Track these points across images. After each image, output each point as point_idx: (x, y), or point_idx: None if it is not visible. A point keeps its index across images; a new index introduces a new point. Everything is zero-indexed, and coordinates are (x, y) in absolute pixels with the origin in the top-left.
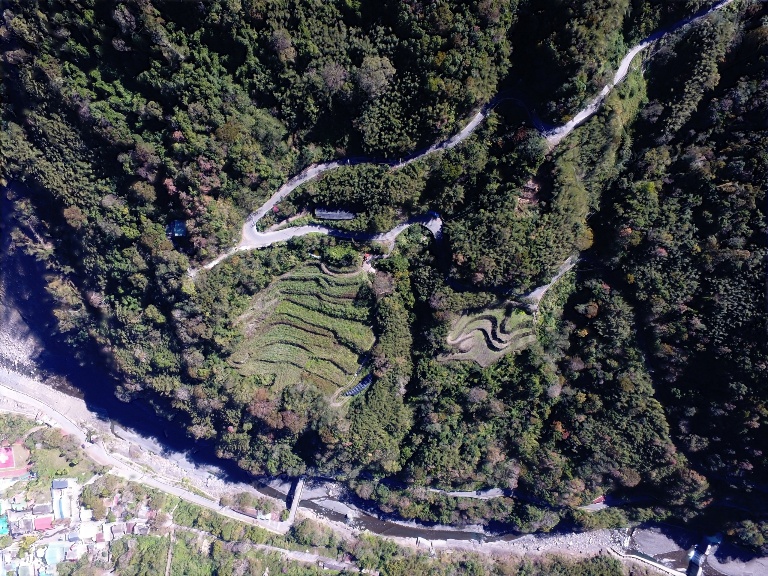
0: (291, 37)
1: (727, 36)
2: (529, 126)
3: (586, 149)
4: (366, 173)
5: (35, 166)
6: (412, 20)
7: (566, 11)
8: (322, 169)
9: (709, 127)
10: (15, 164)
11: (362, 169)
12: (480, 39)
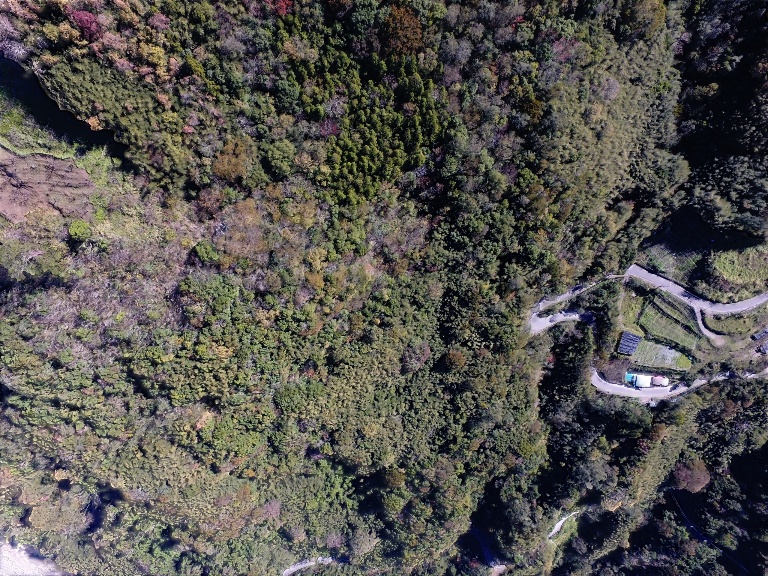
0: (304, 526)
1: (637, 520)
2: (481, 559)
3: (524, 574)
4: (352, 575)
5: (102, 574)
6: (395, 523)
7: (510, 526)
8: (319, 560)
9: (621, 564)
10: (86, 569)
11: (350, 572)
12: (445, 537)
